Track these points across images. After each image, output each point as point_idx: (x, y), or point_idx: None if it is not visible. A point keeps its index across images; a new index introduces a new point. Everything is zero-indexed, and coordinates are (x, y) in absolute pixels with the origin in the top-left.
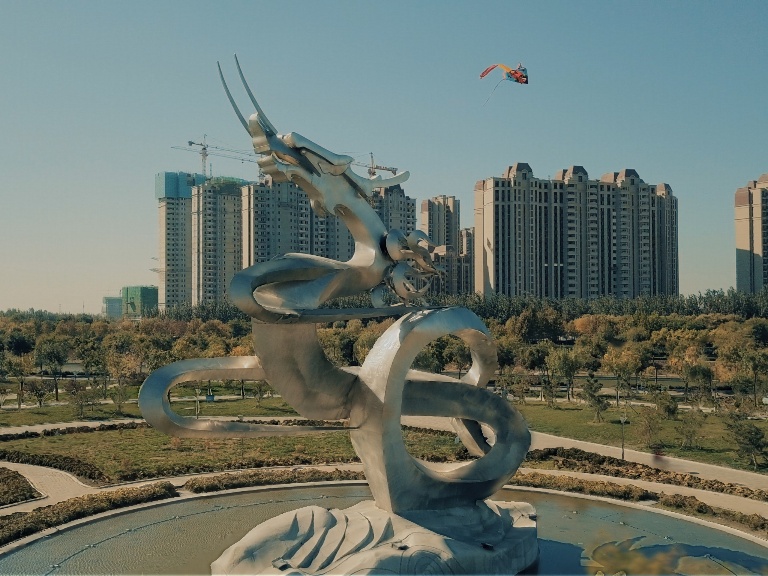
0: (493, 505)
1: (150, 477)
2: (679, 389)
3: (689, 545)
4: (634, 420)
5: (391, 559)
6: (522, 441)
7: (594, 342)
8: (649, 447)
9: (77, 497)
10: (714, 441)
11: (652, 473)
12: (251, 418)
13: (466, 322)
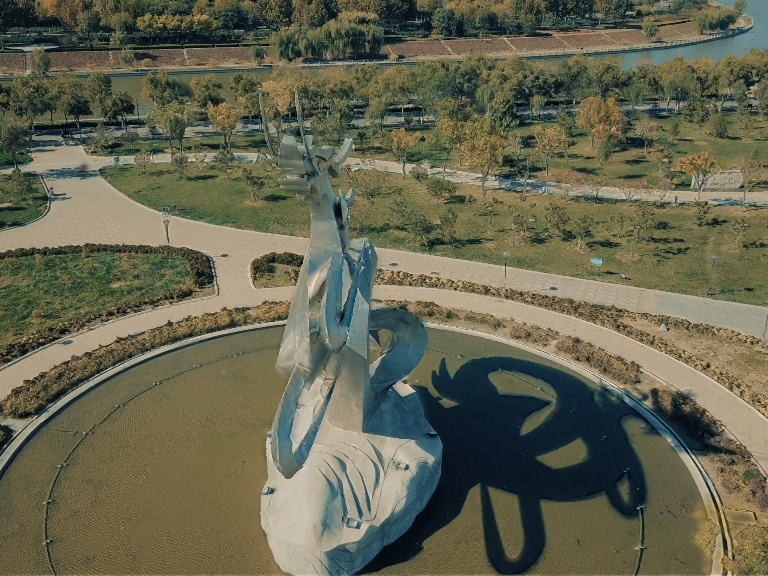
0: None
1: None
2: (243, 120)
3: (477, 359)
4: (281, 193)
5: (411, 483)
6: (421, 340)
7: (163, 80)
8: None
9: None
10: (368, 215)
11: None
12: None
13: None
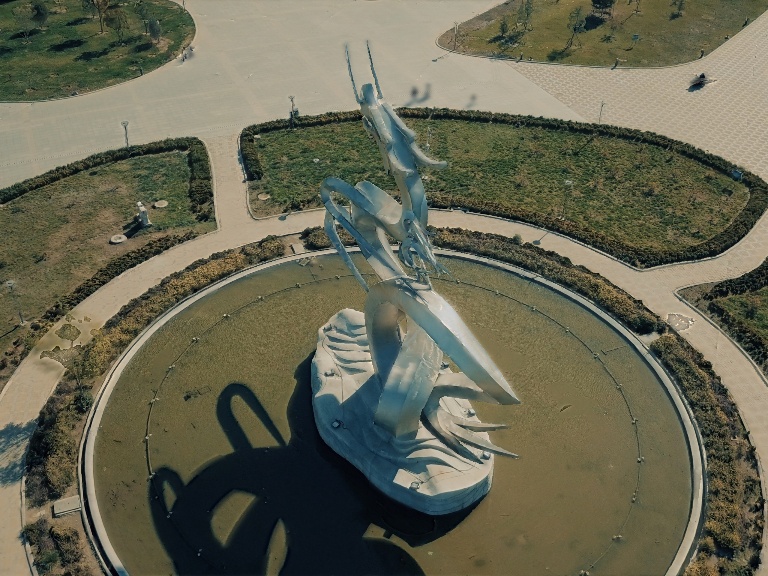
0: (423, 454)
1: (722, 321)
2: None
3: None
4: None
5: None
6: None
7: None
8: None
9: (603, 278)
10: None
11: None
12: None
13: None
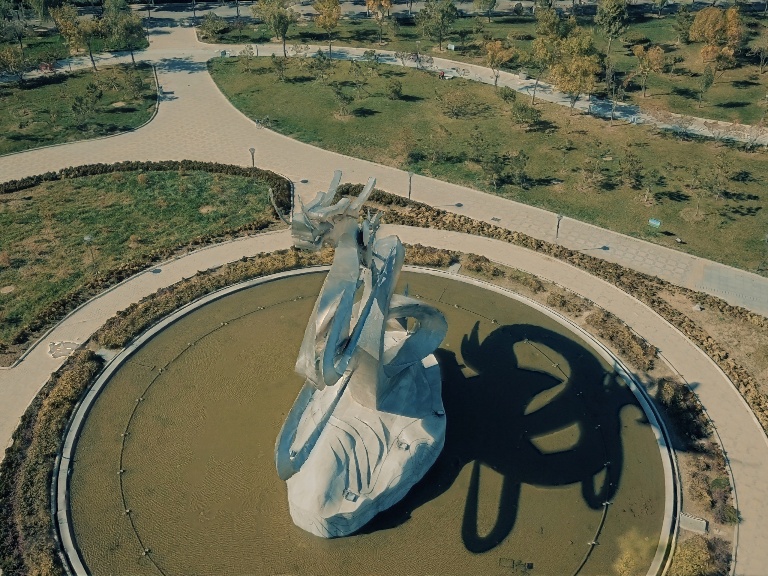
0: None
1: (39, 330)
2: None
3: (508, 326)
4: (370, 106)
5: (408, 463)
6: (441, 328)
7: None
8: (408, 163)
9: (35, 406)
10: None
11: (435, 215)
12: (7, 161)
13: (402, 258)
